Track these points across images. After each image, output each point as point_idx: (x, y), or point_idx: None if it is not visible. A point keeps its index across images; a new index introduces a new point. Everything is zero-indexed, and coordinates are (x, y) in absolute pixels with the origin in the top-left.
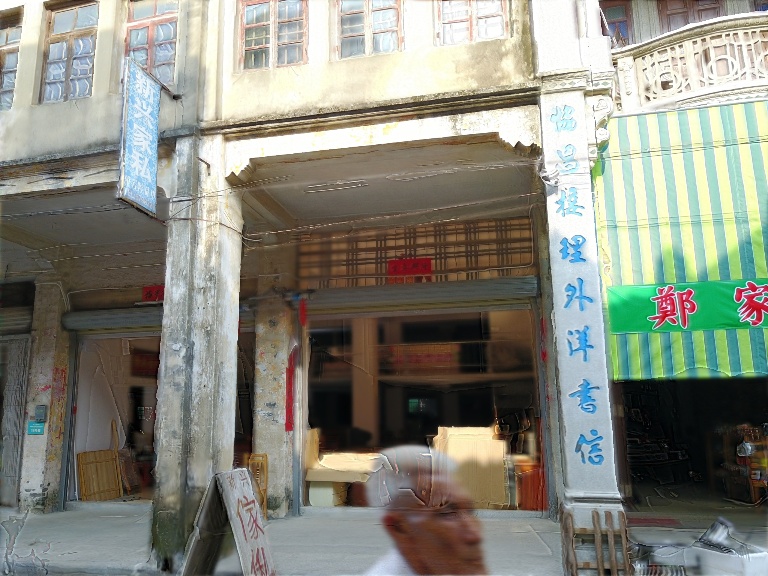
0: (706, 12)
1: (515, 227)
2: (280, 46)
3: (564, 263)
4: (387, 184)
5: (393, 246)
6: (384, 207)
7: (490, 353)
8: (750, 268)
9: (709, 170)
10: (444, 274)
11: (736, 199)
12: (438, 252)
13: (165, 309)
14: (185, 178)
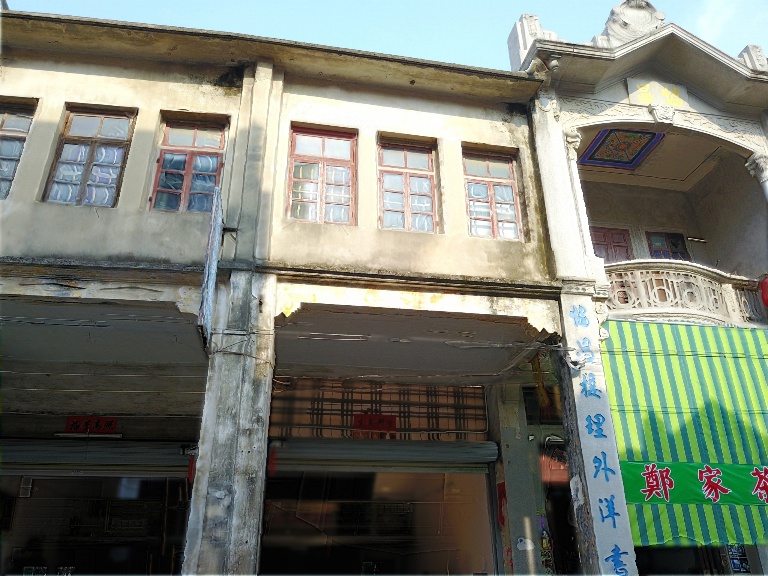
0: (619, 248)
1: (470, 395)
2: (327, 204)
3: (590, 437)
4: (383, 342)
5: (359, 400)
6: (361, 361)
7: (449, 515)
8: (706, 454)
9: (669, 372)
10: (408, 432)
11: (689, 398)
12: (402, 410)
13: (201, 449)
14: (240, 312)
